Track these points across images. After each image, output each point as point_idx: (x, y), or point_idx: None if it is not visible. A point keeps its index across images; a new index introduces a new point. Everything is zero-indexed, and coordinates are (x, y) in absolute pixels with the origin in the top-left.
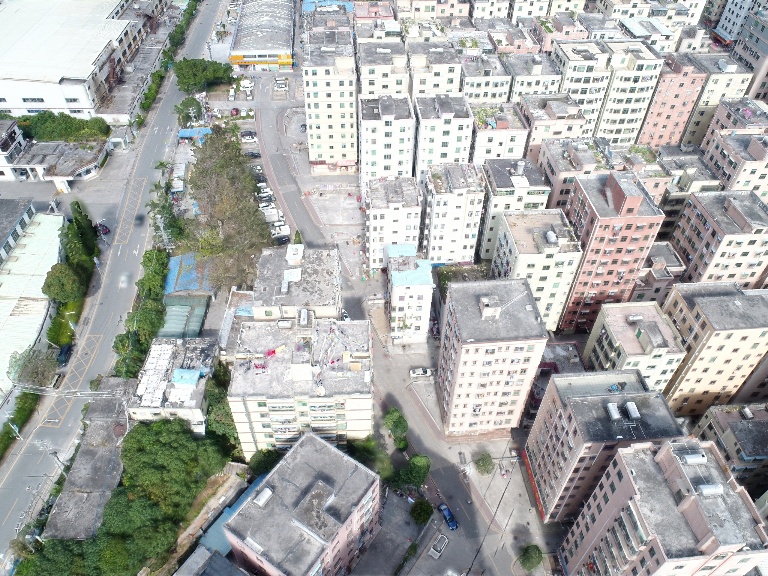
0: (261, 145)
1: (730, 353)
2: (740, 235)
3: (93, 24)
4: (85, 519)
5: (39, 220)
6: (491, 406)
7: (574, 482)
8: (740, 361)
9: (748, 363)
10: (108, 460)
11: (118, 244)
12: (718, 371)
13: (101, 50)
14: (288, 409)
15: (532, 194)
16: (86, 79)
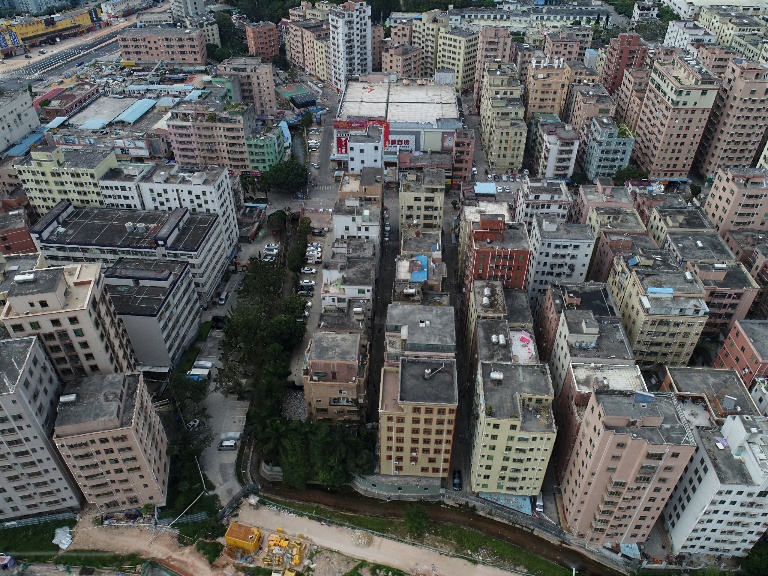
0: None
1: None
2: None
3: (754, 1)
4: None
5: None
6: None
7: None
8: None
9: None
10: None
11: None
12: None
13: (727, 5)
14: None
15: None
16: (695, 6)
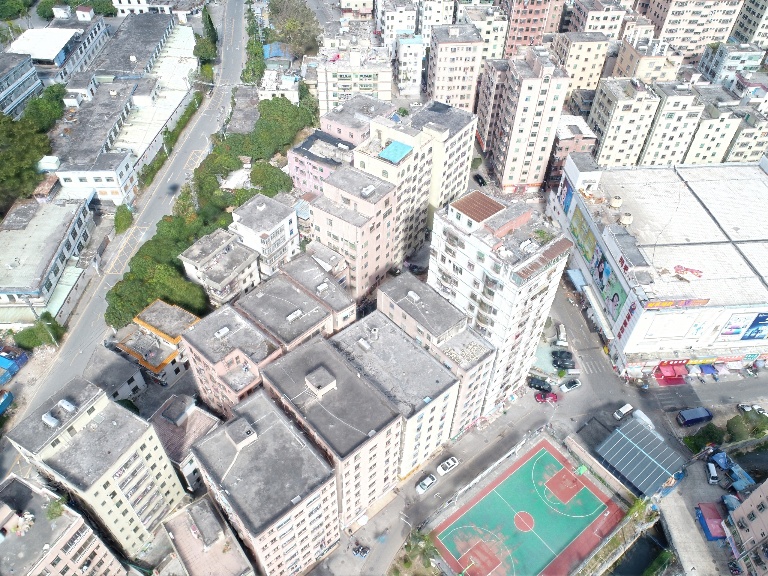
0: (306, 5)
1: (584, 62)
2: (597, 12)
3: None
4: (246, 128)
5: (178, 28)
6: (456, 99)
7: (496, 109)
8: (591, 70)
9: (596, 72)
10: (251, 112)
11: (226, 45)
12: (580, 78)
13: None
14: (348, 78)
15: (483, 3)
16: None
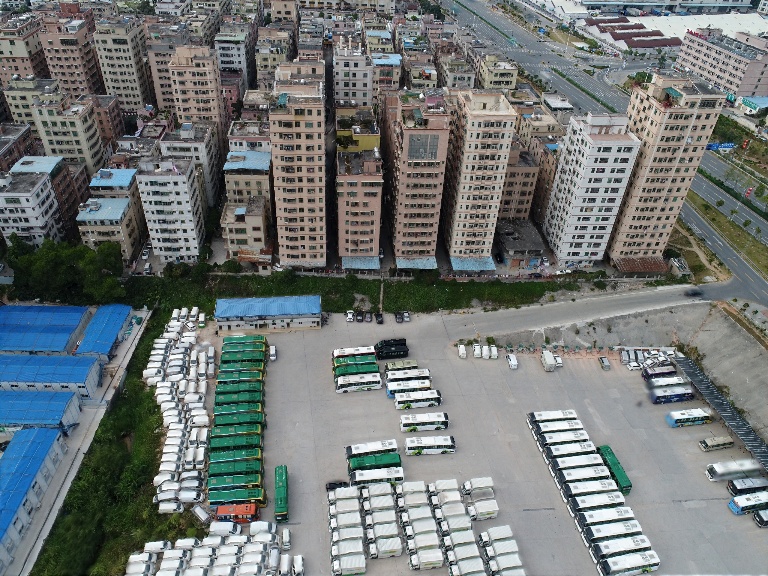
0: None
1: None
2: None
3: None
4: None
5: None
6: None
7: None
8: None
9: None
10: None
11: None
12: None
13: None
14: None
15: None
16: None
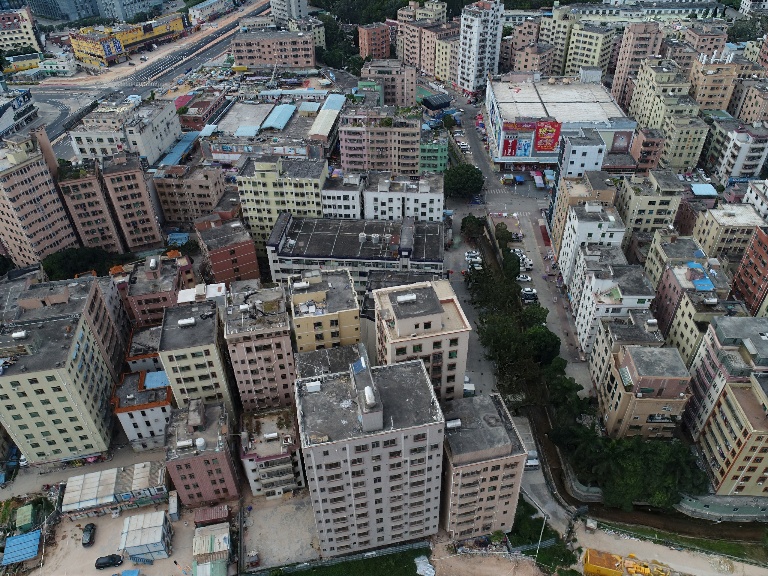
0: None
1: None
2: None
3: None
4: None
5: None
6: None
7: None
8: None
9: None
10: None
11: None
12: None
13: None
14: None
15: None
16: None
